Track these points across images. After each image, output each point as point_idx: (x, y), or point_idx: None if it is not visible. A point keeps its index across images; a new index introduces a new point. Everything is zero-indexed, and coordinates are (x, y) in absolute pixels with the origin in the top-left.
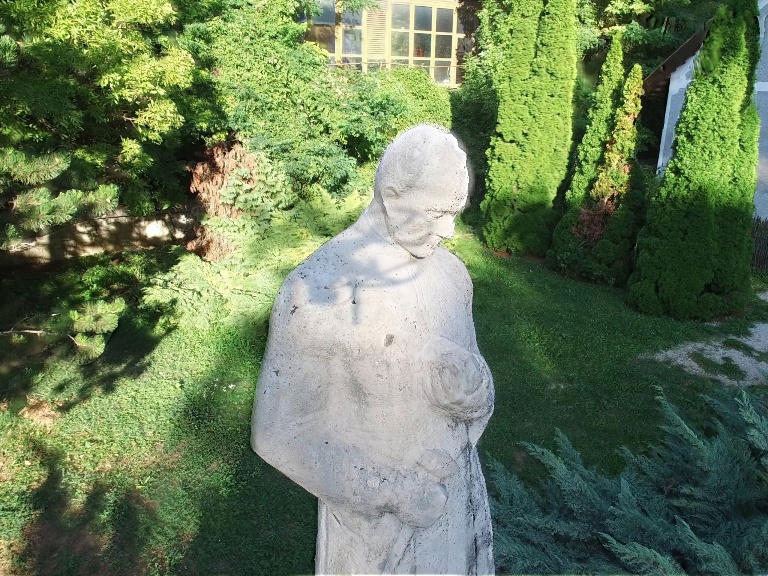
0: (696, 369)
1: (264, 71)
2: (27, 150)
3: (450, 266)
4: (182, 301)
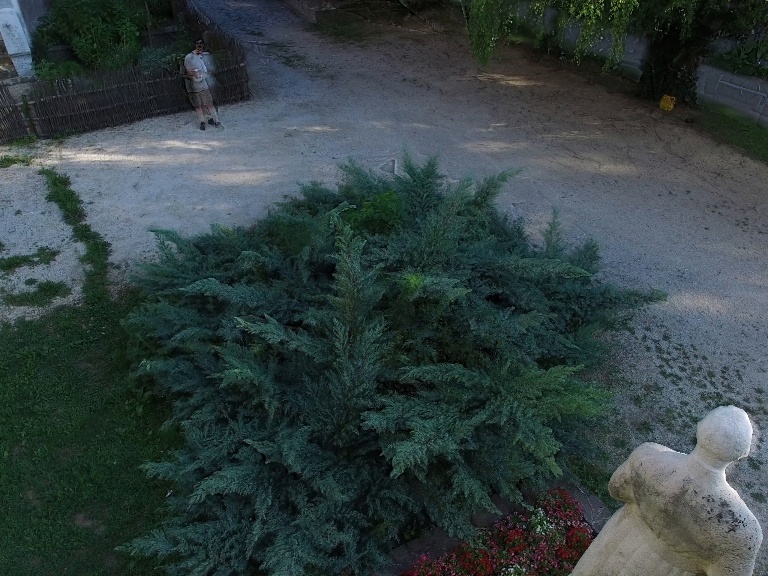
0: (32, 311)
1: None
2: None
3: None
4: None
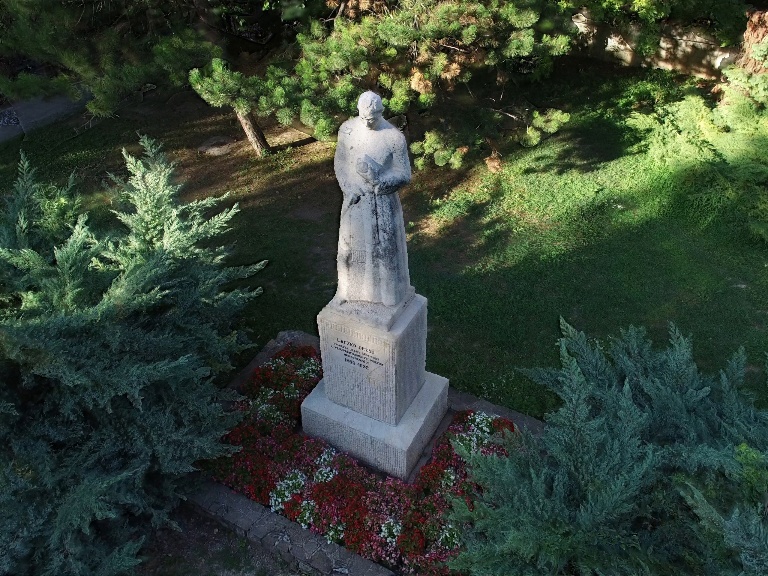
0: None
1: None
2: (538, 1)
3: (390, 137)
4: (656, 133)
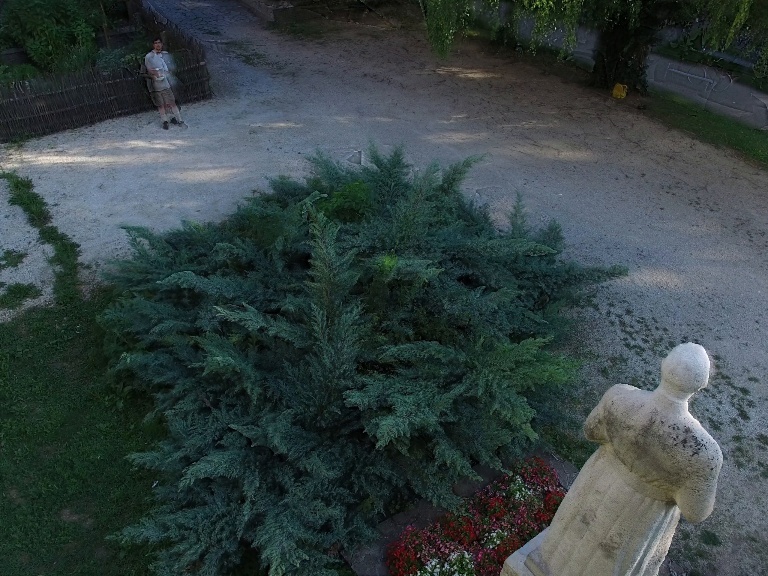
0: (2, 314)
1: None
2: None
3: None
4: None
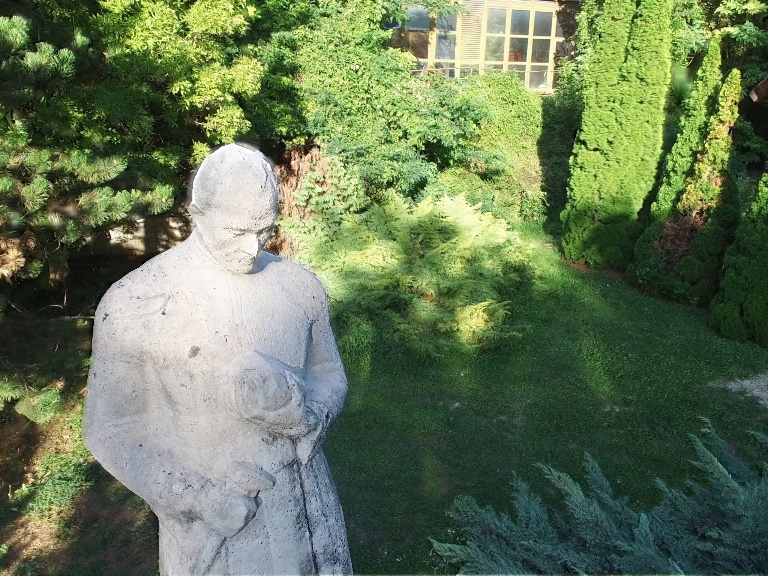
0: None
1: (346, 77)
2: (97, 152)
3: (293, 282)
4: None
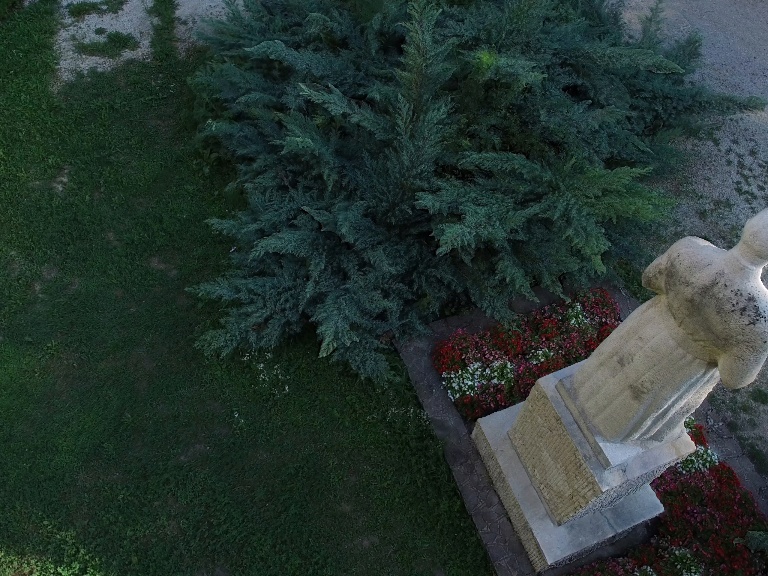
0: (103, 63)
1: None
2: None
3: None
4: None
